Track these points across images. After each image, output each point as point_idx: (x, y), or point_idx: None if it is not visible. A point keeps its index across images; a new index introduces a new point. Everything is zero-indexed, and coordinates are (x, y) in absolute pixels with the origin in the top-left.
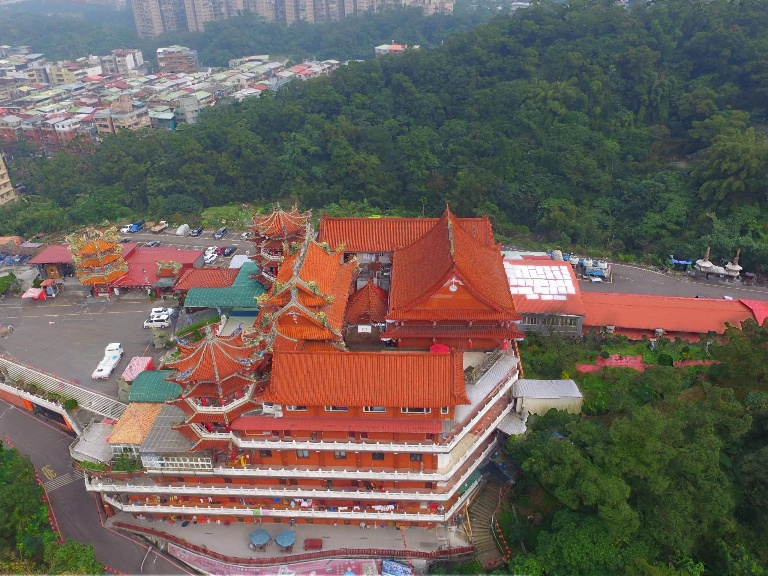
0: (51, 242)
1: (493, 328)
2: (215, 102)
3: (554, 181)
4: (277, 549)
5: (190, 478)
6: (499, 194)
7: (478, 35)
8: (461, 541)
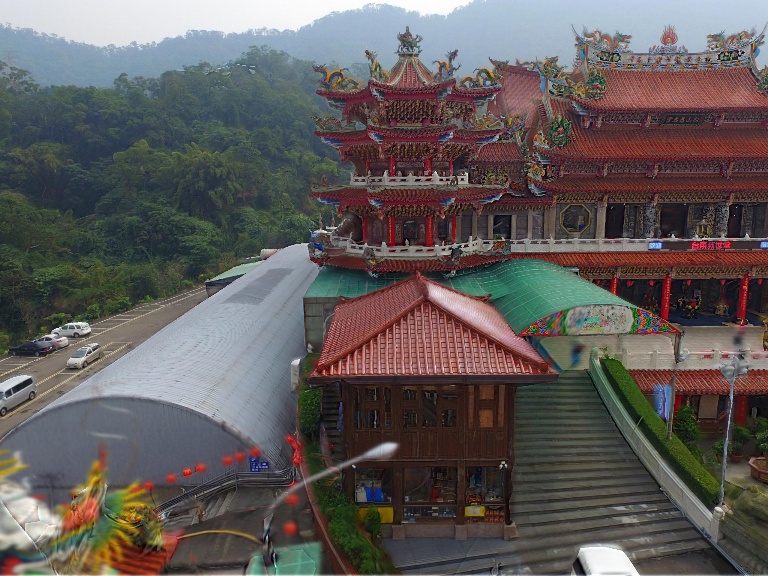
0: None
1: None
2: None
3: None
4: None
5: None
6: None
7: None
8: None
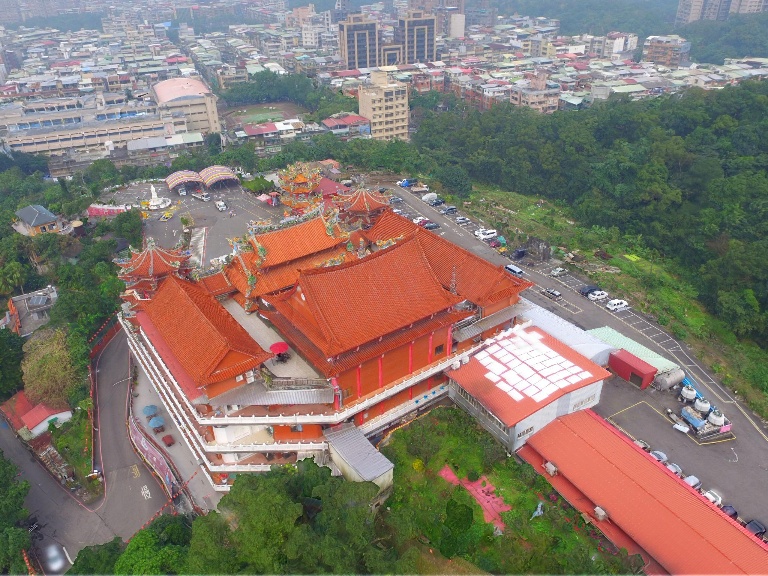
0: (350, 174)
1: None
2: (609, 96)
3: None
4: None
5: None
6: None
7: None
8: None
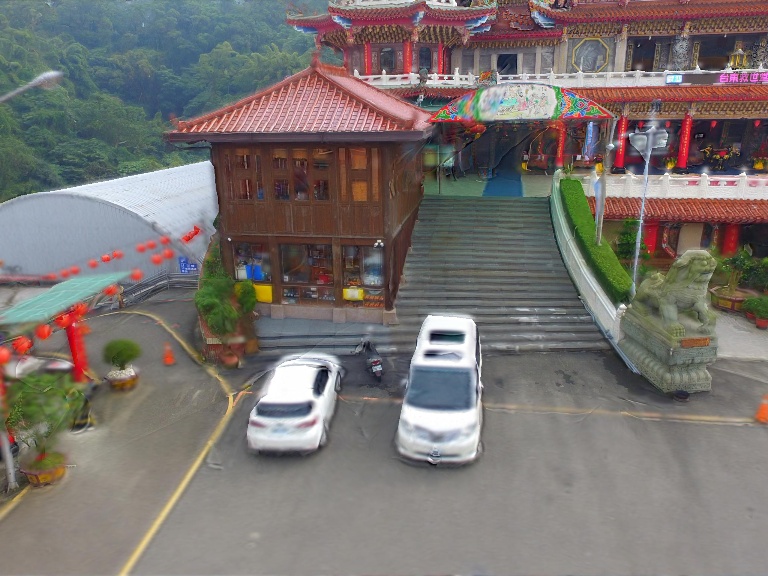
0: None
1: None
2: None
3: None
4: None
5: None
6: (44, 175)
7: None
8: None
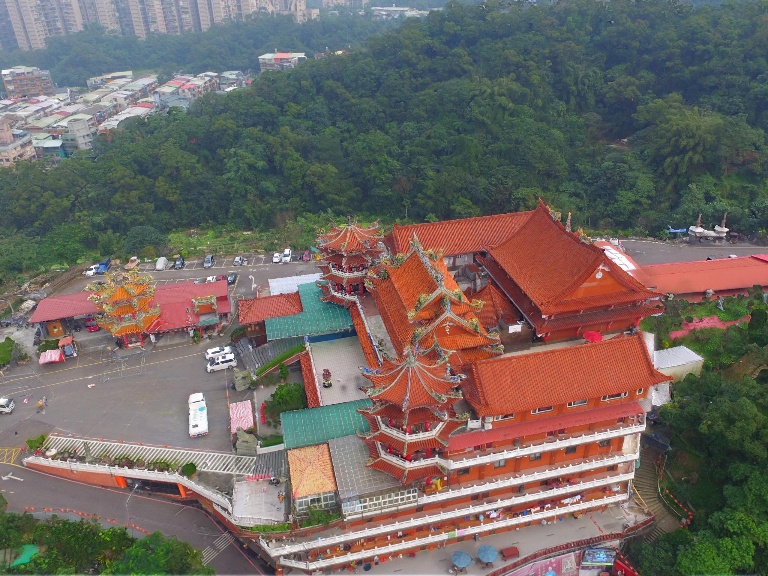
0: (5, 298)
1: (630, 308)
2: (118, 124)
3: (520, 172)
4: (477, 567)
5: (382, 516)
6: (471, 189)
7: (403, 38)
8: (638, 515)
